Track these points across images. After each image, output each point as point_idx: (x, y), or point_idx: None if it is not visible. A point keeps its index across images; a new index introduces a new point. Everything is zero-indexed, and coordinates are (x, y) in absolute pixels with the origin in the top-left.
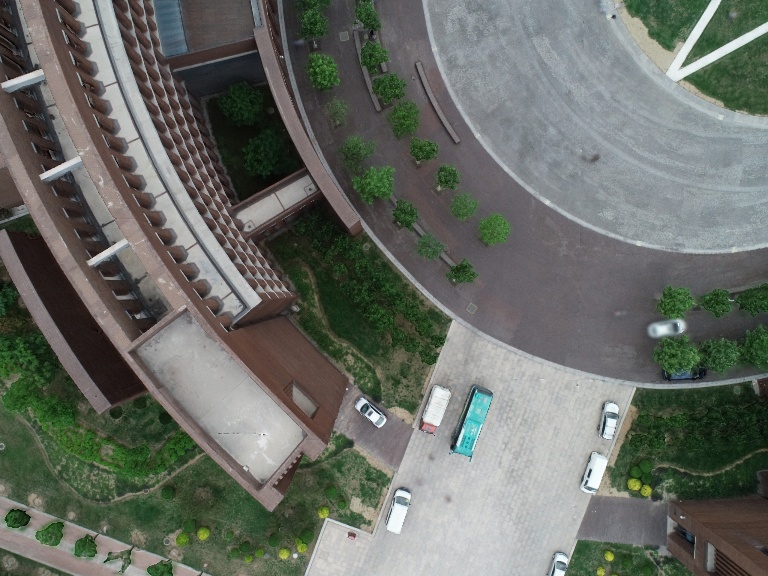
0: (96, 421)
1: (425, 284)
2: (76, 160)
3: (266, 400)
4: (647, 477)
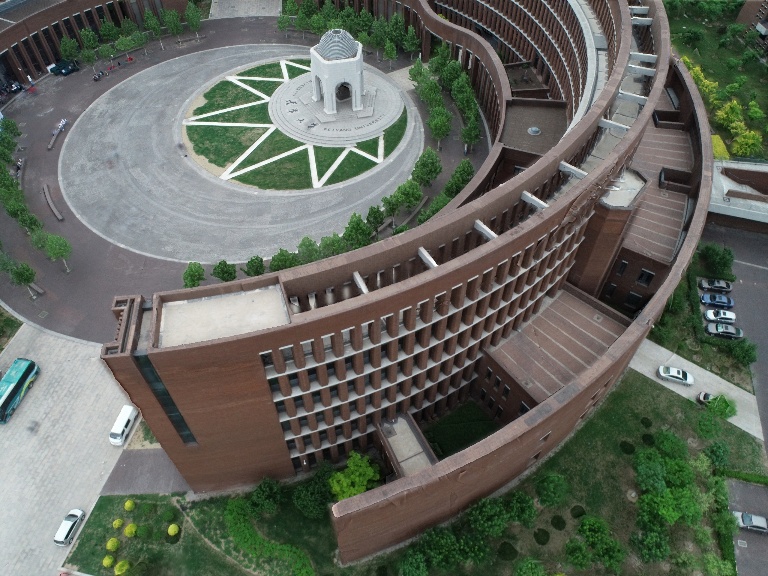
0: None
1: (8, 302)
2: None
3: None
4: None
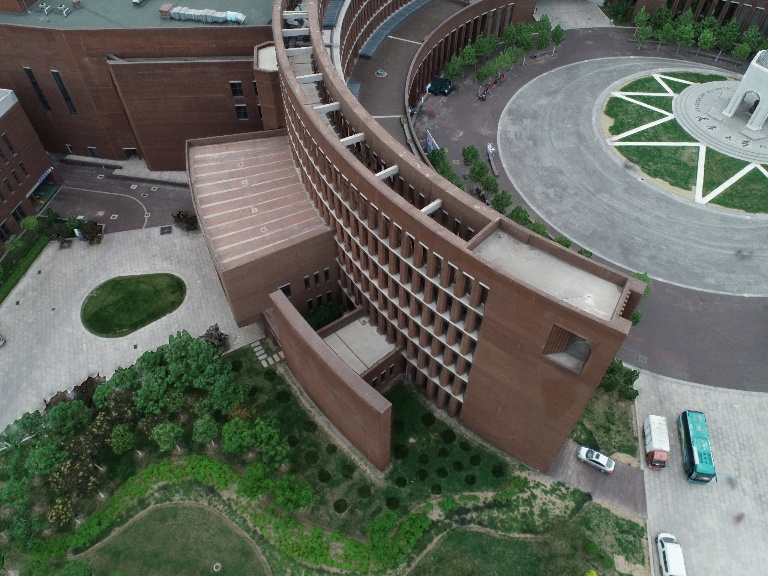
0: (320, 519)
1: None
2: (390, 169)
3: (579, 274)
4: None
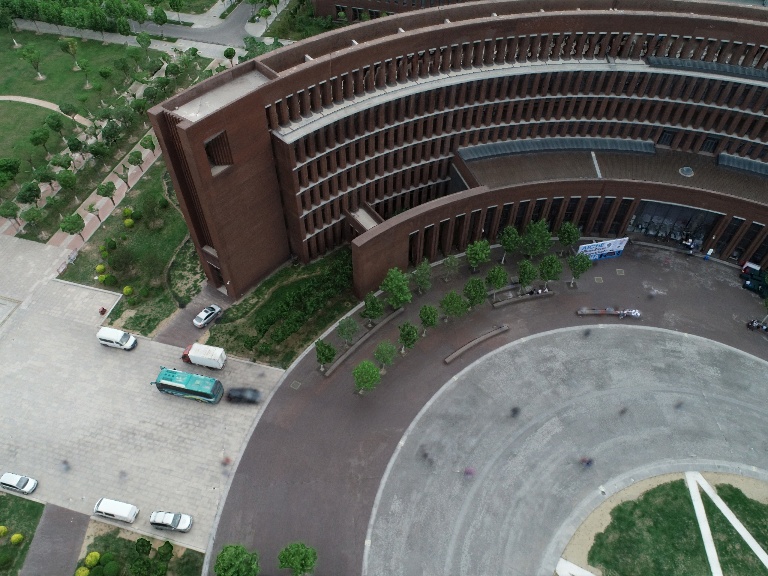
0: None
1: None
2: None
3: None
4: (99, 570)
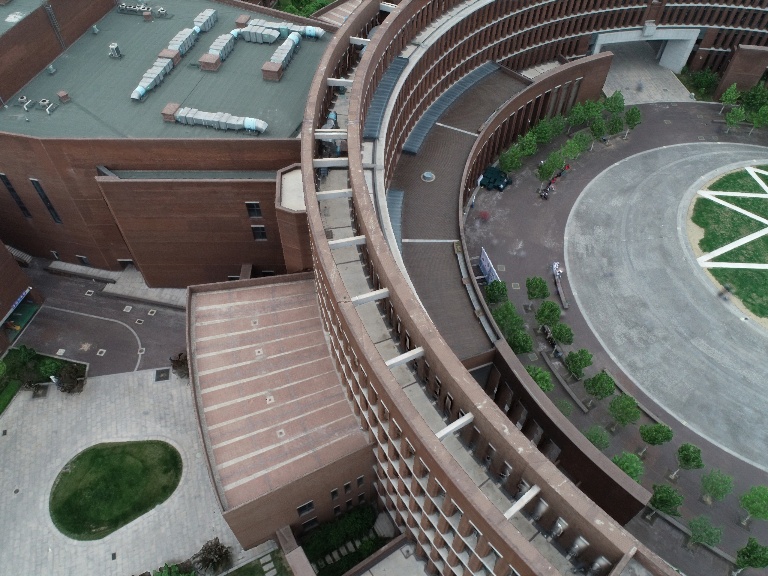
0: None
1: None
2: (463, 420)
3: None
4: None
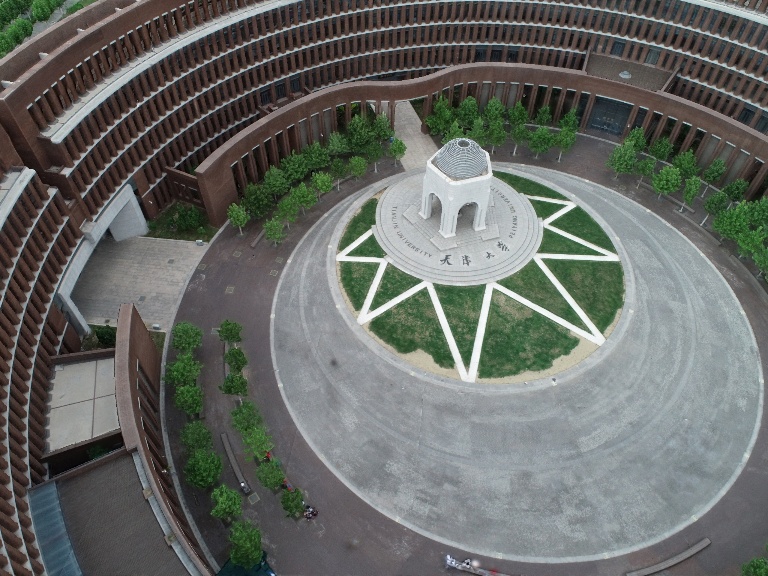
0: None
1: None
2: None
3: None
4: None
